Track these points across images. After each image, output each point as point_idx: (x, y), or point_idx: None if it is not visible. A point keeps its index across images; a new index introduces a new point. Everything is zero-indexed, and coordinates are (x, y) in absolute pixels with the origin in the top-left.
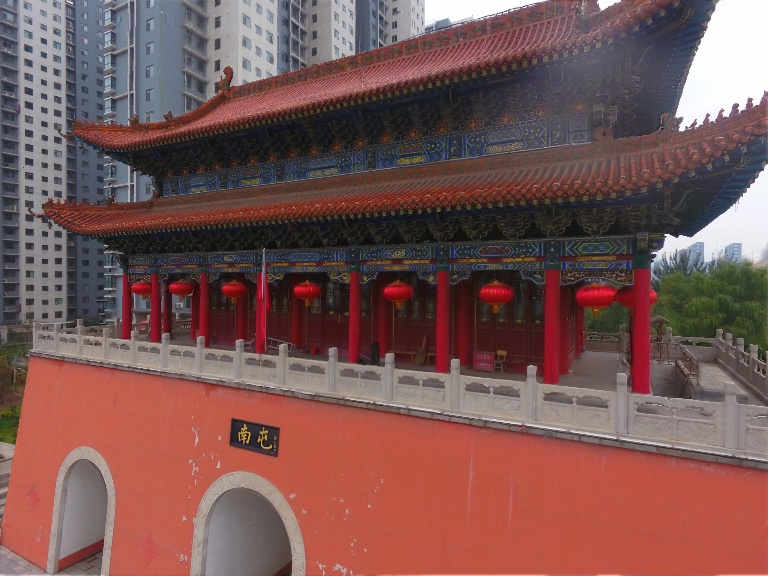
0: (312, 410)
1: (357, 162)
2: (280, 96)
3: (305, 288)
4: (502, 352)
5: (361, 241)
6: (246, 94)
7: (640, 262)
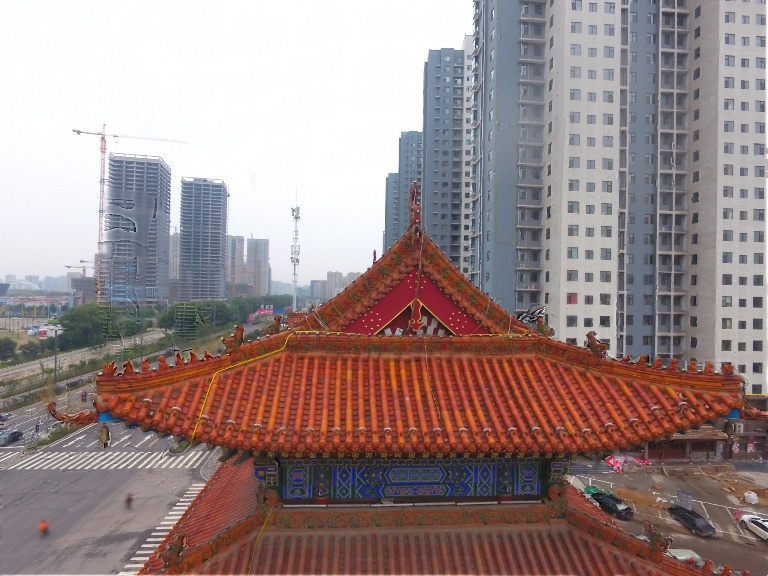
0: None
1: None
2: None
3: None
4: None
5: None
6: None
7: None
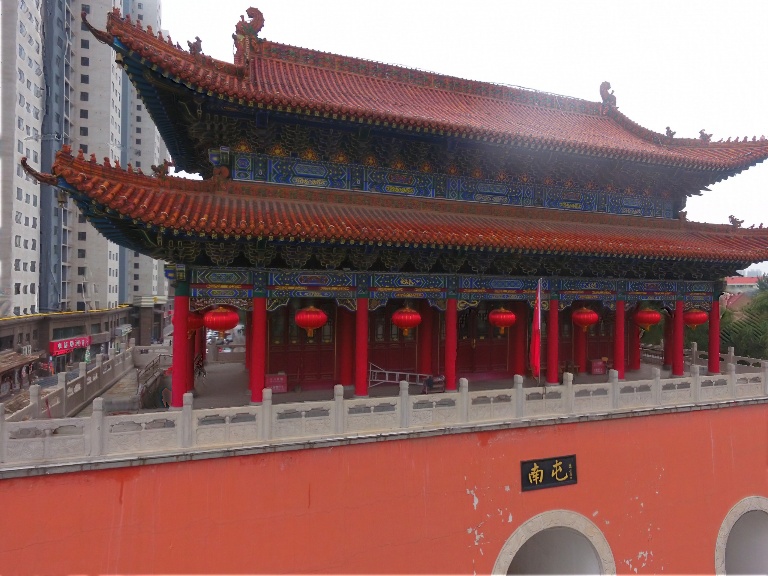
0: (603, 429)
1: (527, 196)
2: (370, 87)
3: (513, 316)
4: (605, 358)
5: (559, 272)
6: (291, 59)
7: (717, 297)
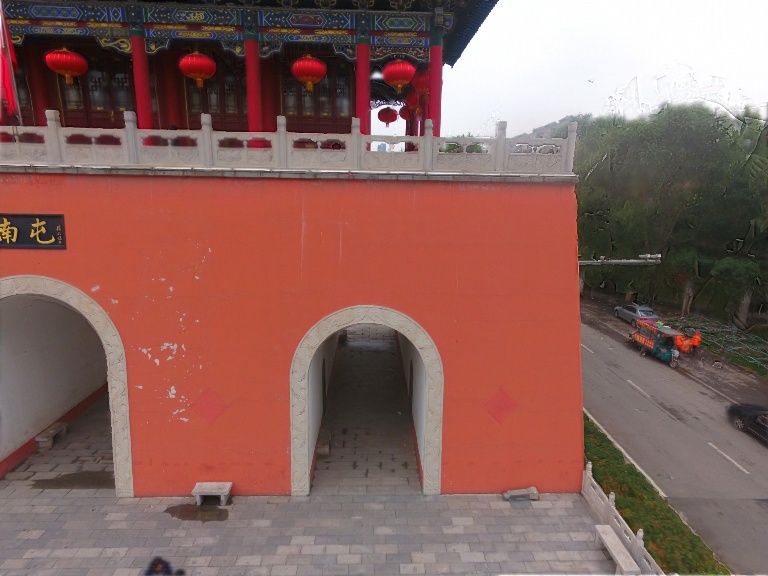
0: (109, 188)
1: None
2: None
3: (64, 55)
4: None
5: None
6: None
7: (436, 39)
